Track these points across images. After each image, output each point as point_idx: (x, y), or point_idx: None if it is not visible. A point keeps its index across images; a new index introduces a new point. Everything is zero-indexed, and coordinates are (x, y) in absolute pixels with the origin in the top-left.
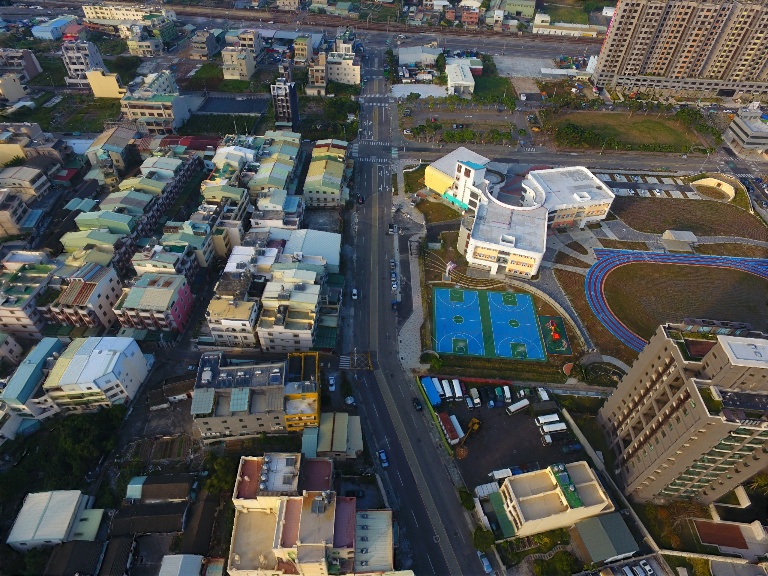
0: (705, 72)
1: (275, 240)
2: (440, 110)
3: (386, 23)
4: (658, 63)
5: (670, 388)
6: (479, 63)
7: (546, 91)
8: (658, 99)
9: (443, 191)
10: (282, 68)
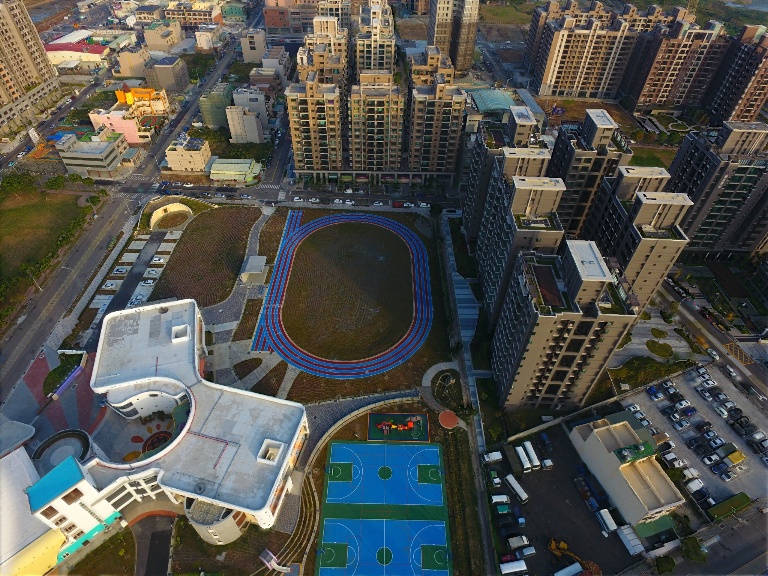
0: None
1: None
2: None
3: None
4: None
5: (576, 335)
6: None
7: None
8: None
9: (53, 562)
10: None
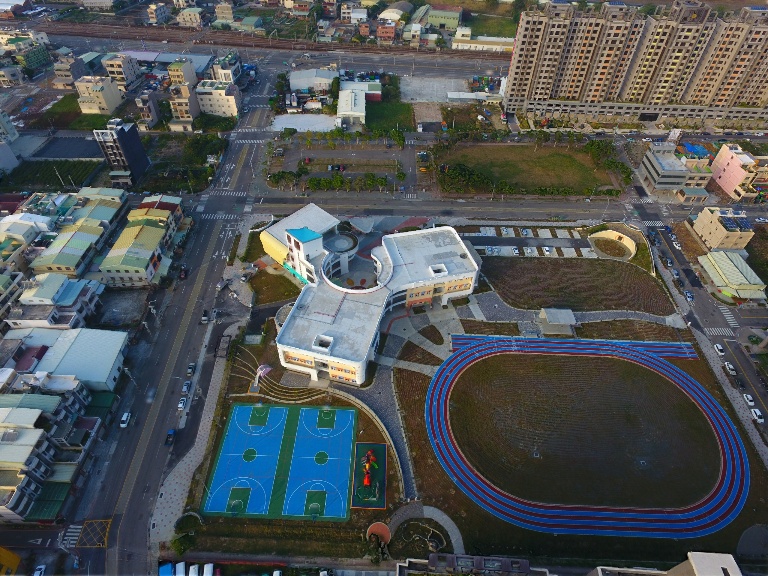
0: (624, 94)
1: (34, 347)
2: (320, 147)
3: (293, 40)
4: (571, 86)
5: None
6: (378, 88)
7: (449, 119)
8: (573, 126)
9: (281, 262)
10: (140, 102)
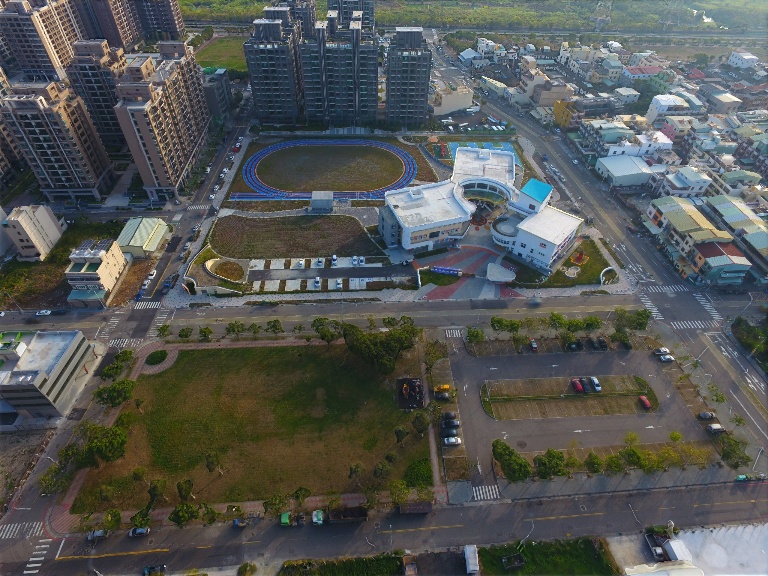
0: None
1: None
2: None
3: None
4: None
5: None
6: None
7: None
8: None
9: None
10: None
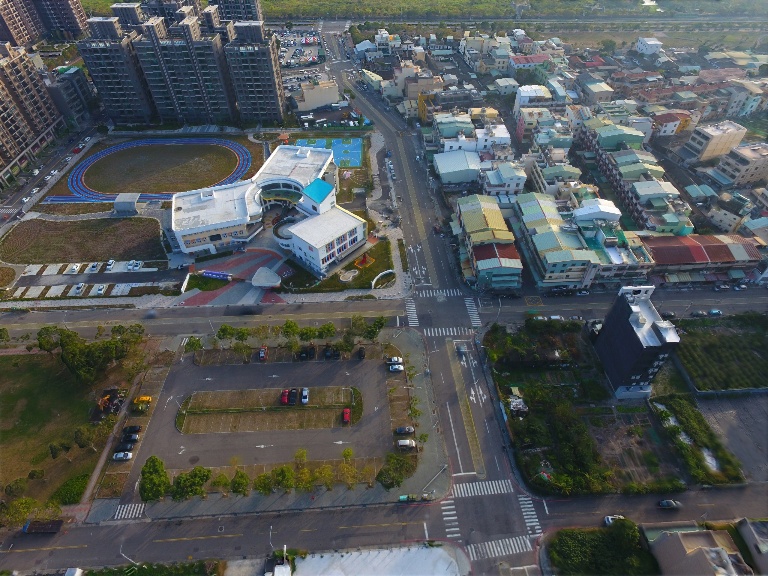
0: None
1: None
2: None
3: None
4: None
5: None
6: None
7: None
8: None
9: None
10: None
